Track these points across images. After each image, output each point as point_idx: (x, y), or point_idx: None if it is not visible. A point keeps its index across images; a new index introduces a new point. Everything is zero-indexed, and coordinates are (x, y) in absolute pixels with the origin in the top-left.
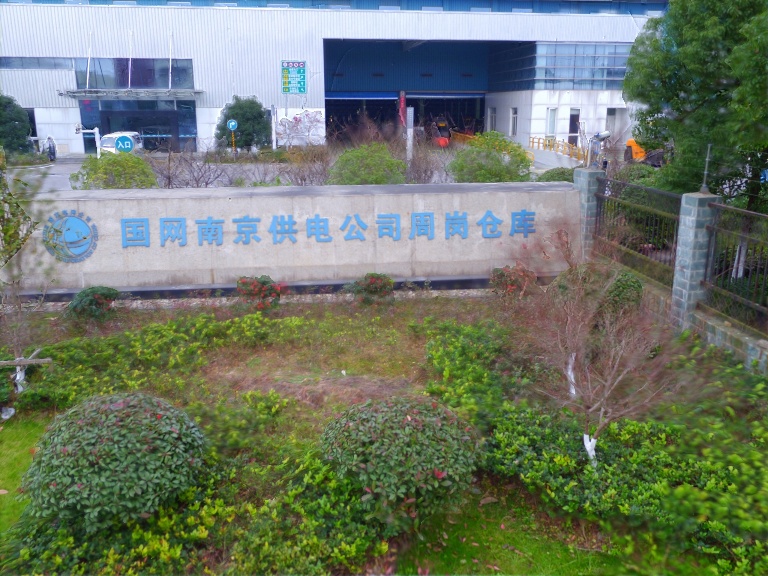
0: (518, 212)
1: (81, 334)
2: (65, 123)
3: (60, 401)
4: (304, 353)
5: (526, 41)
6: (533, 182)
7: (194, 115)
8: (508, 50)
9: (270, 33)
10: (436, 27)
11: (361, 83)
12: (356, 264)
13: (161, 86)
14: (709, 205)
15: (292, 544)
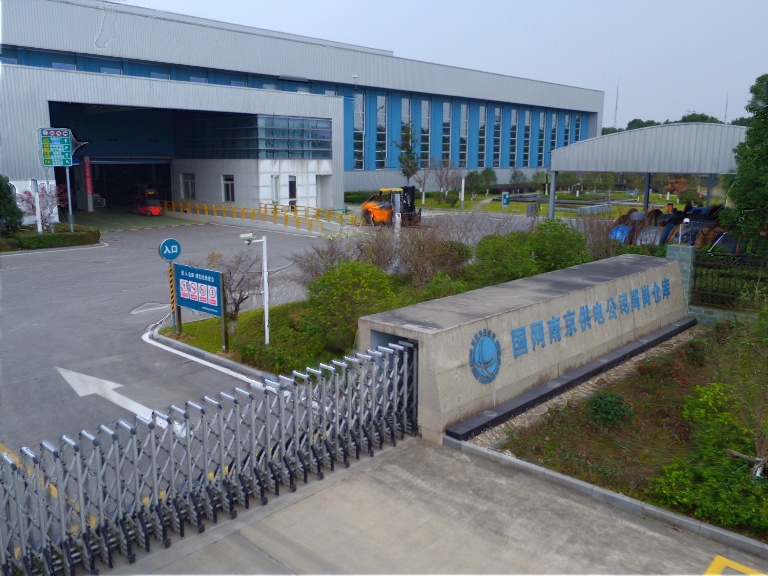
0: (664, 281)
1: None
2: None
3: None
4: None
5: (249, 113)
6: (618, 256)
7: None
8: (210, 119)
9: None
10: (168, 95)
11: None
12: (615, 338)
13: None
14: None
15: None
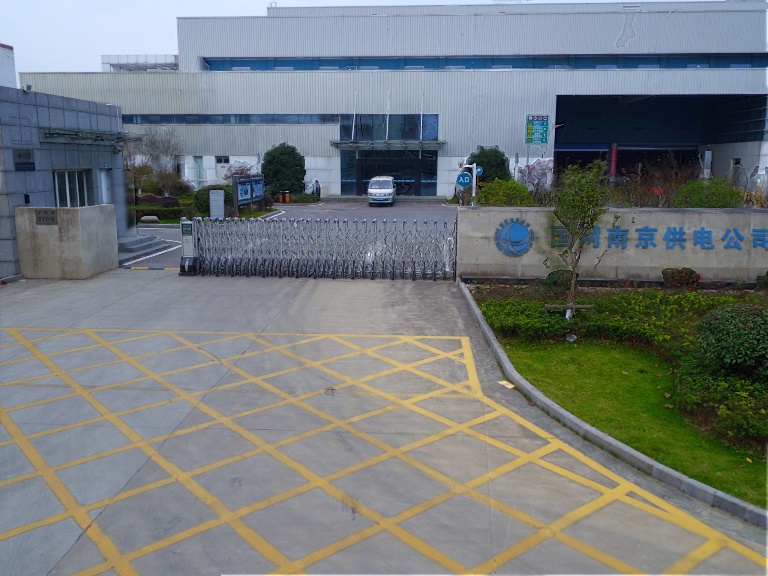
0: None
1: None
2: (327, 169)
3: (610, 331)
4: None
5: (756, 94)
6: None
7: (435, 163)
8: (730, 103)
9: (509, 91)
10: (665, 83)
11: (575, 136)
12: (733, 268)
13: (410, 138)
14: None
15: None
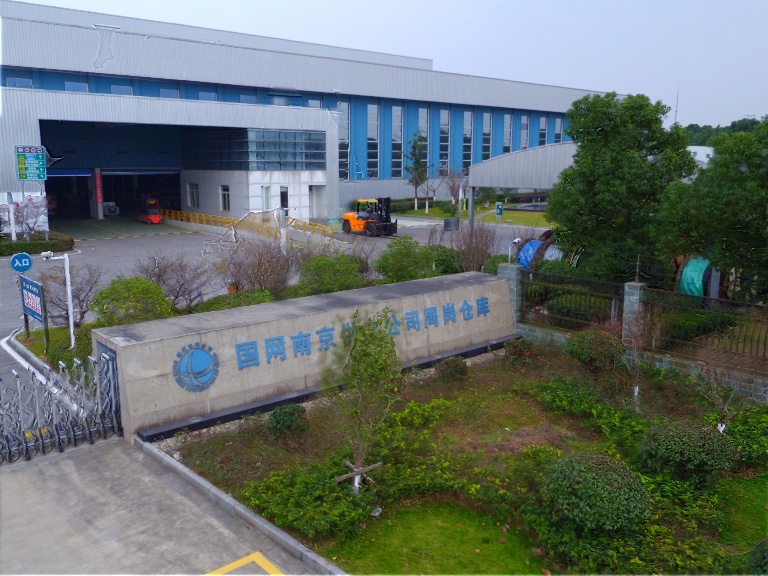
0: (480, 299)
1: None
2: None
3: (411, 490)
4: (466, 423)
5: (239, 127)
6: (457, 274)
7: None
8: (210, 132)
9: None
10: (156, 112)
11: None
12: (397, 353)
13: None
14: (643, 289)
15: None
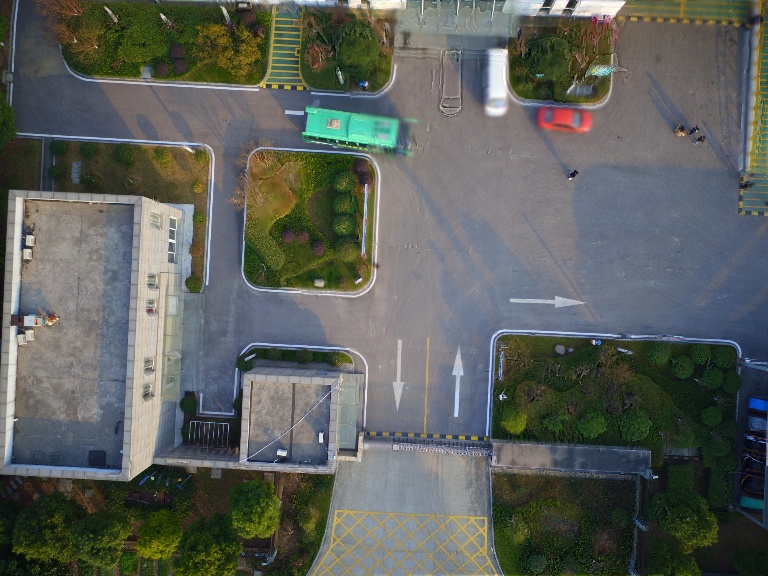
0: None
1: None
2: None
3: None
4: (559, 510)
5: None
6: (640, 451)
7: None
8: None
9: None
10: None
11: None
12: None
13: None
14: None
15: (554, 571)
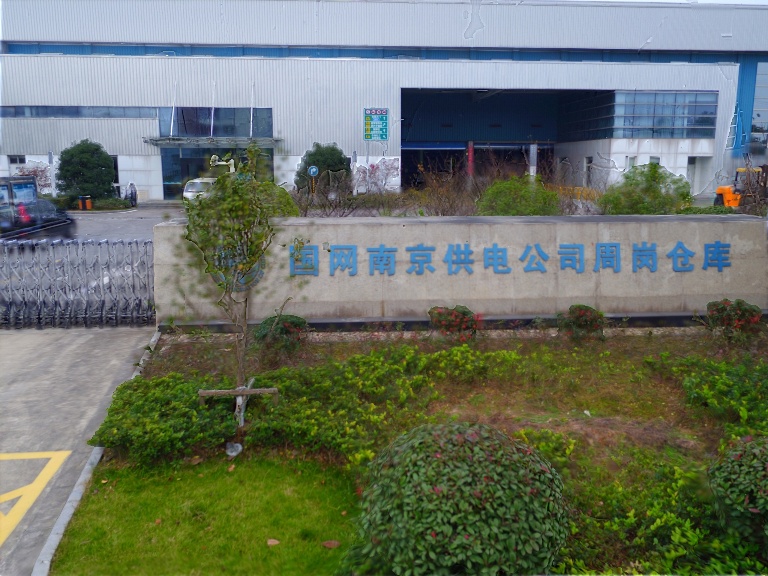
0: (712, 244)
1: (267, 366)
2: (146, 170)
3: (295, 437)
4: (529, 391)
5: (605, 90)
6: None
7: (271, 163)
8: (581, 100)
9: (349, 83)
10: (514, 76)
11: (430, 133)
12: (536, 298)
13: (241, 134)
14: None
15: None
